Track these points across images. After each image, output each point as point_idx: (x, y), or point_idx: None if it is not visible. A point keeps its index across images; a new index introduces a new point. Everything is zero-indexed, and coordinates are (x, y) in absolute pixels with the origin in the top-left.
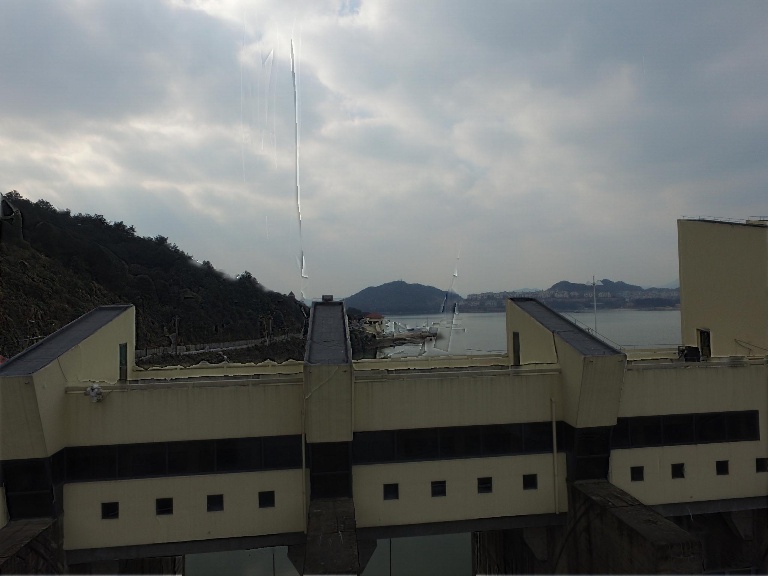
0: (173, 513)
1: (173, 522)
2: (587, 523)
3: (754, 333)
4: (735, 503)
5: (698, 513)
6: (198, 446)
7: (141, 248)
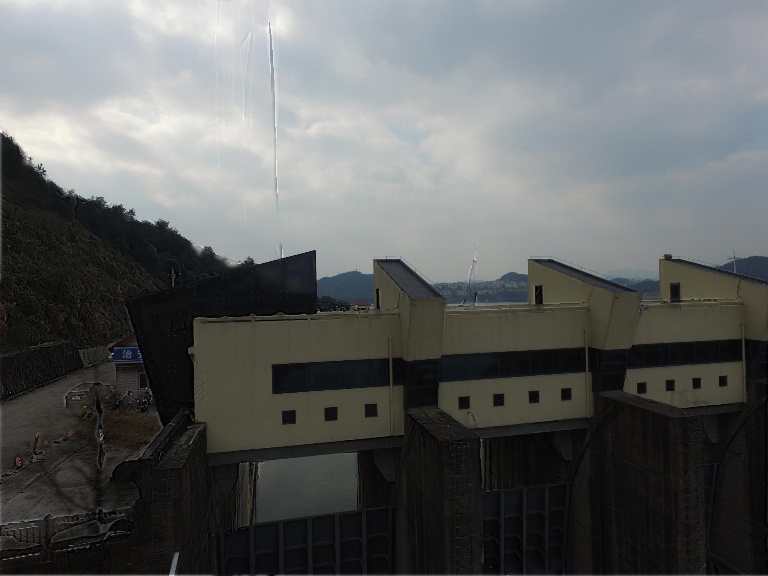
0: (675, 390)
1: (675, 396)
2: None
3: None
4: None
5: None
6: (683, 346)
7: (145, 232)
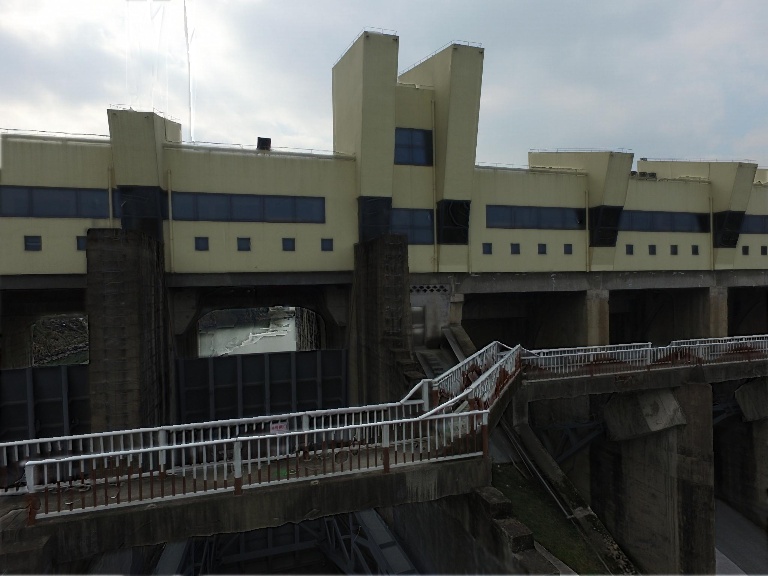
0: None
1: None
2: None
3: (348, 146)
4: (303, 277)
5: (267, 284)
6: None
7: None
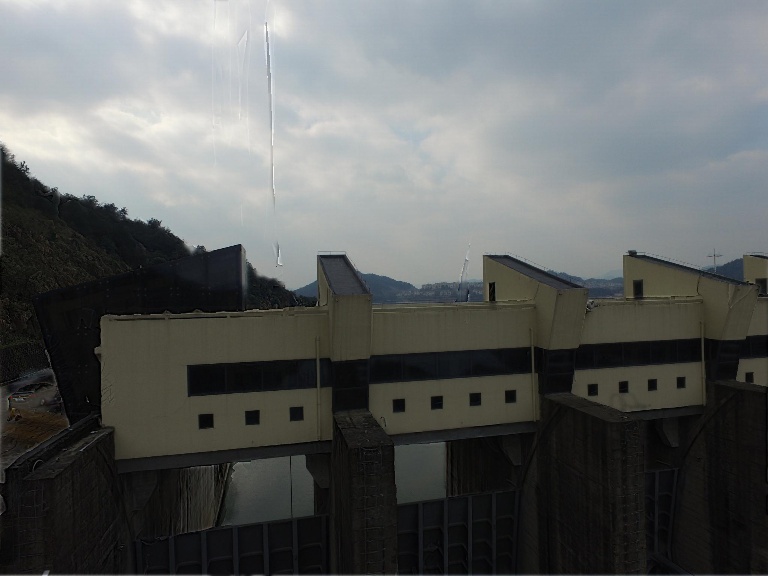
0: (629, 392)
1: (629, 398)
2: None
3: None
4: None
5: None
6: (638, 346)
7: (137, 231)
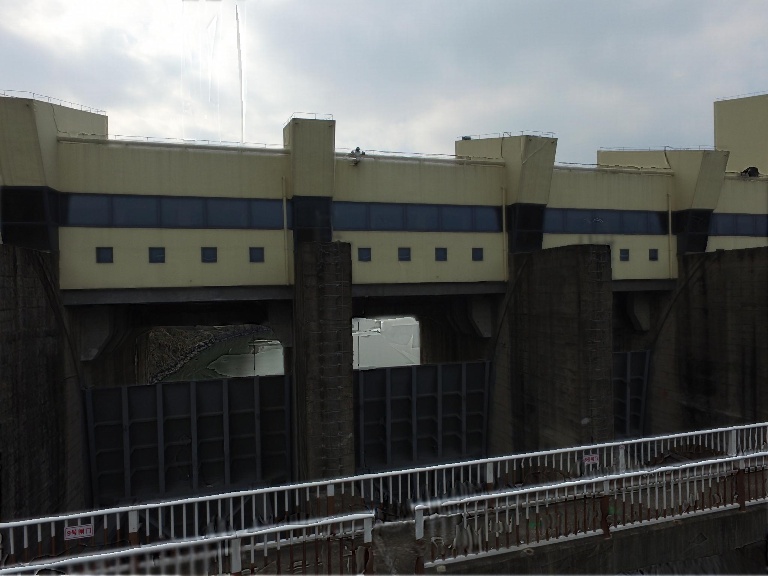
0: (411, 260)
1: (411, 267)
2: (702, 273)
3: None
4: None
5: None
6: (426, 210)
7: None
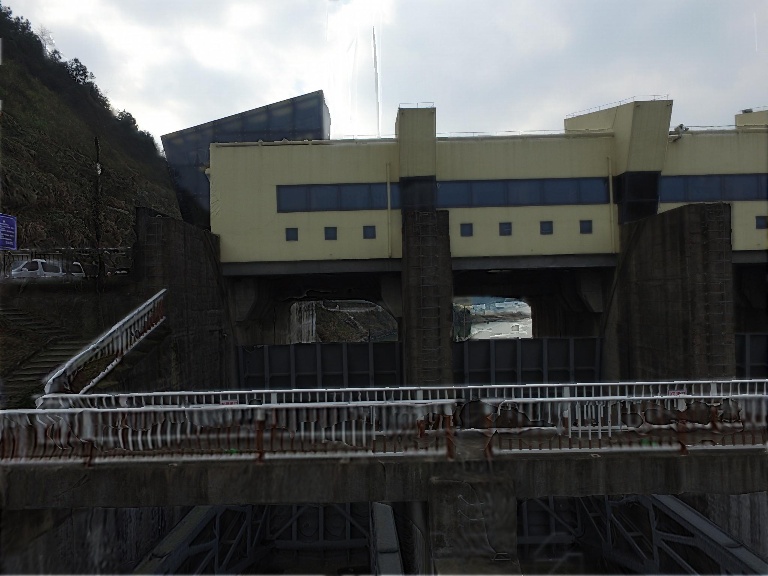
0: None
1: None
2: None
3: None
4: None
5: None
6: (743, 180)
7: None
